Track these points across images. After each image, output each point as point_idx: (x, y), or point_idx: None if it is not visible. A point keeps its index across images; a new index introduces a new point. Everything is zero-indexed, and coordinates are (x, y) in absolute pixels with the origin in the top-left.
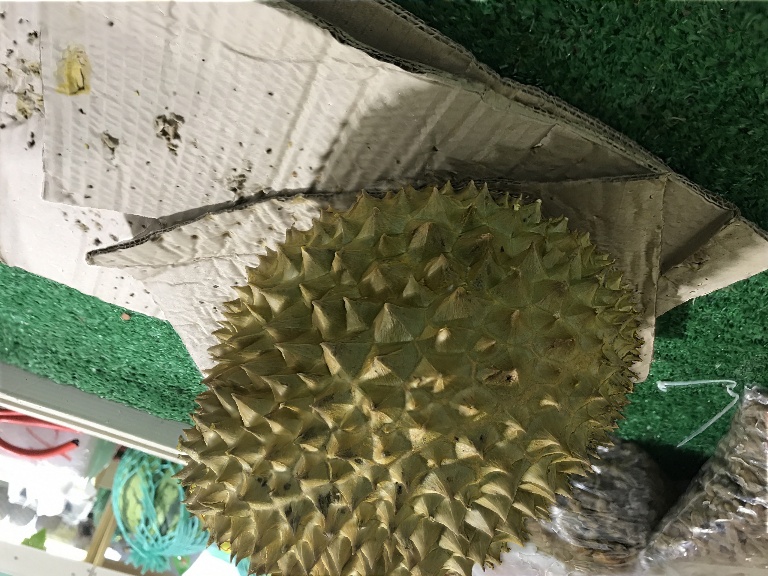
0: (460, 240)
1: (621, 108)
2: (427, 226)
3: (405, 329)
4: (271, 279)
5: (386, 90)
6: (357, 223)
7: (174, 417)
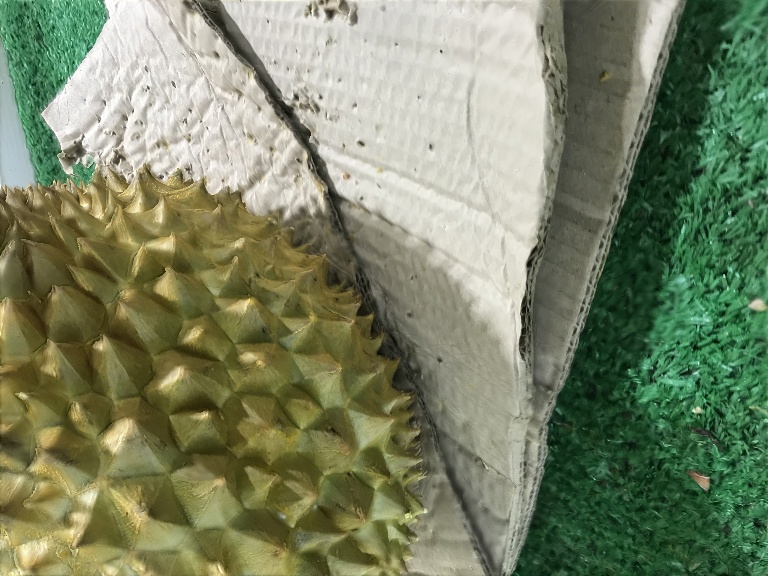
0: (344, 478)
1: (554, 529)
2: (343, 451)
3: (201, 514)
4: (195, 255)
5: (487, 308)
6: (313, 340)
7: (5, 38)
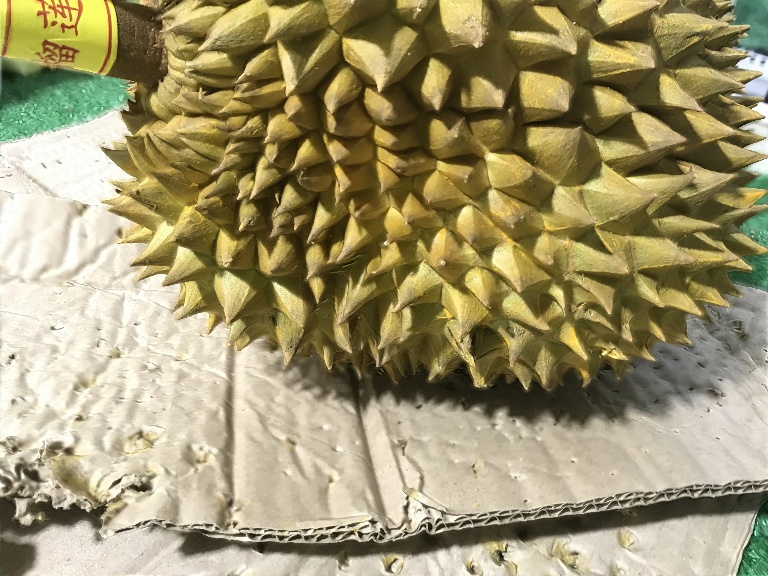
0: None
1: None
2: None
3: None
4: None
5: None
6: None
7: None
